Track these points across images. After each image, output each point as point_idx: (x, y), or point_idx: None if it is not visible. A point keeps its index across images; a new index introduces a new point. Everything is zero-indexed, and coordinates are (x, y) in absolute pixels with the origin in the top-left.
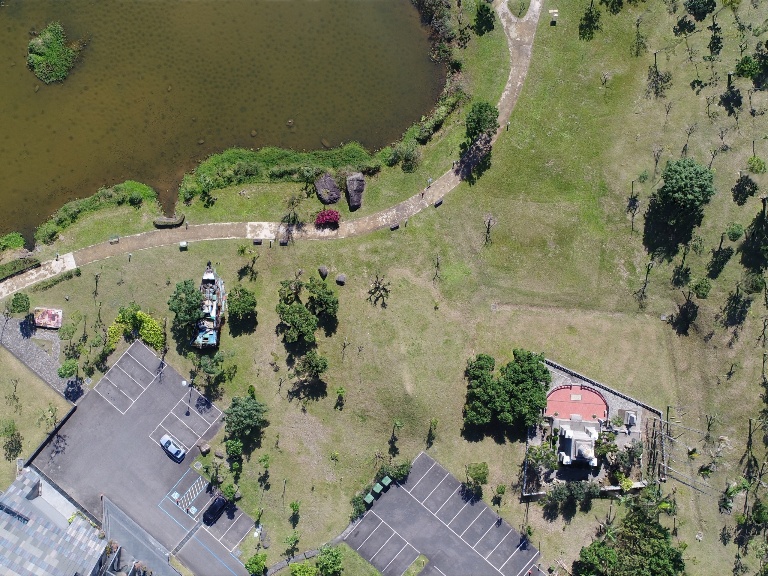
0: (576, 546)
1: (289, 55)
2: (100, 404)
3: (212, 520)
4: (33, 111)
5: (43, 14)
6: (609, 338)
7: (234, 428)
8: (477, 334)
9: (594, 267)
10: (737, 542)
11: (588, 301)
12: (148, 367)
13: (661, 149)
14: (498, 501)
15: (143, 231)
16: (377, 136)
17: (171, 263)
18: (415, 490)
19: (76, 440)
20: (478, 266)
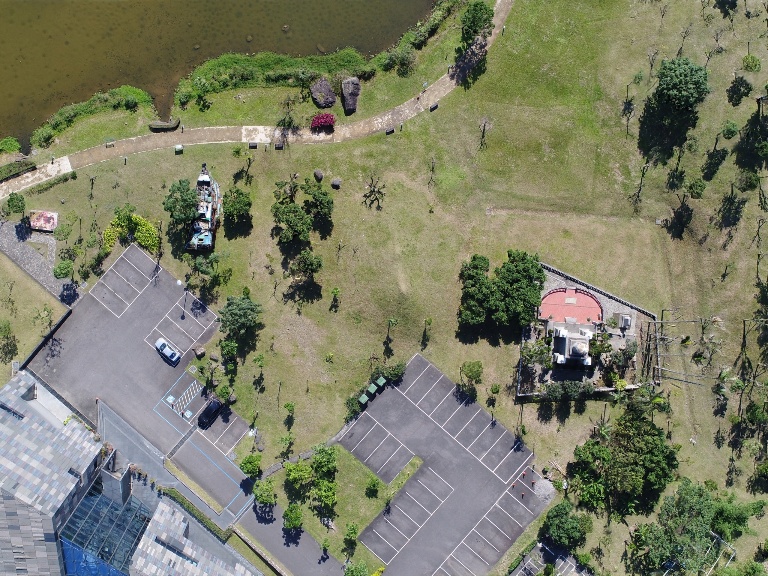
0: (570, 448)
1: None
2: (95, 308)
3: (207, 423)
4: (29, 16)
5: None
6: (604, 242)
7: (229, 327)
8: (472, 238)
9: (589, 171)
10: (731, 445)
11: (583, 205)
12: (143, 271)
13: (656, 51)
14: (492, 403)
15: (139, 135)
16: (373, 41)
17: (166, 167)
18: (410, 391)
19: (71, 344)
20: (473, 170)
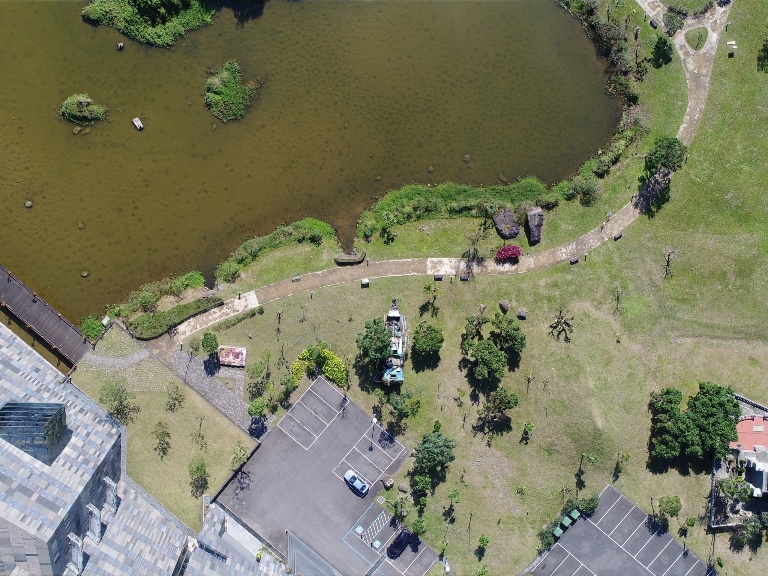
0: None
1: (465, 90)
2: (284, 440)
3: (397, 554)
4: (211, 150)
5: (219, 53)
6: None
7: (425, 464)
8: (658, 367)
9: None
10: None
11: None
12: (331, 403)
13: None
14: (684, 532)
15: (324, 268)
16: (554, 170)
17: (353, 300)
18: (602, 523)
19: (260, 476)
20: (658, 299)
